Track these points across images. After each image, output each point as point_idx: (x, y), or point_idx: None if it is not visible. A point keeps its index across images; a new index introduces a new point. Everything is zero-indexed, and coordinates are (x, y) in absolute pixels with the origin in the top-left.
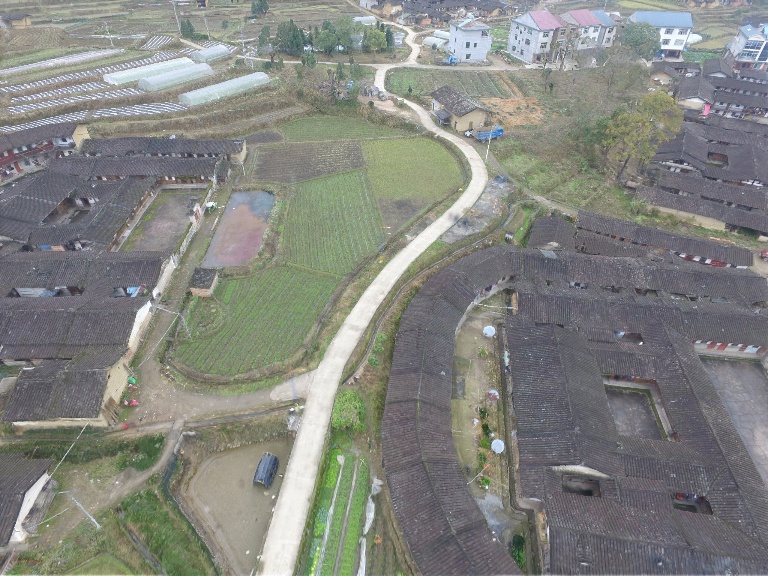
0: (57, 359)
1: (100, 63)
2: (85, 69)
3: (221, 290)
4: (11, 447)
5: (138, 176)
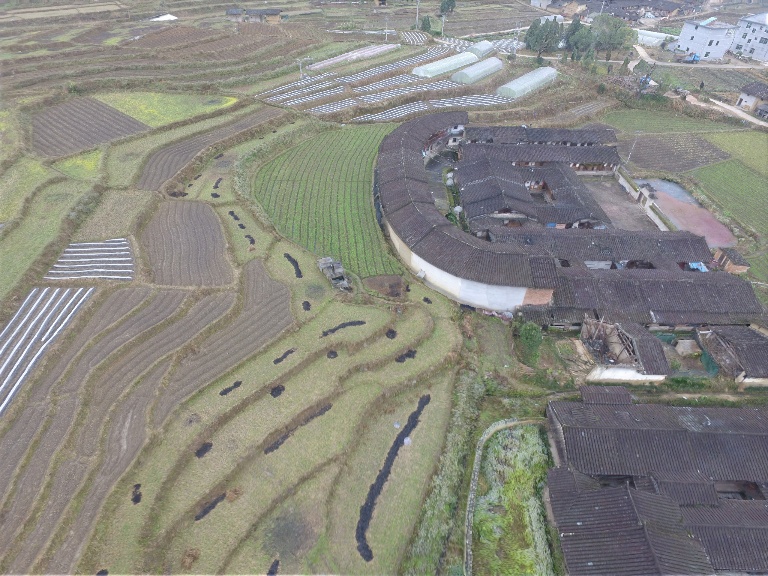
0: (701, 325)
1: (393, 57)
2: (387, 62)
3: None
4: (748, 402)
5: (550, 162)
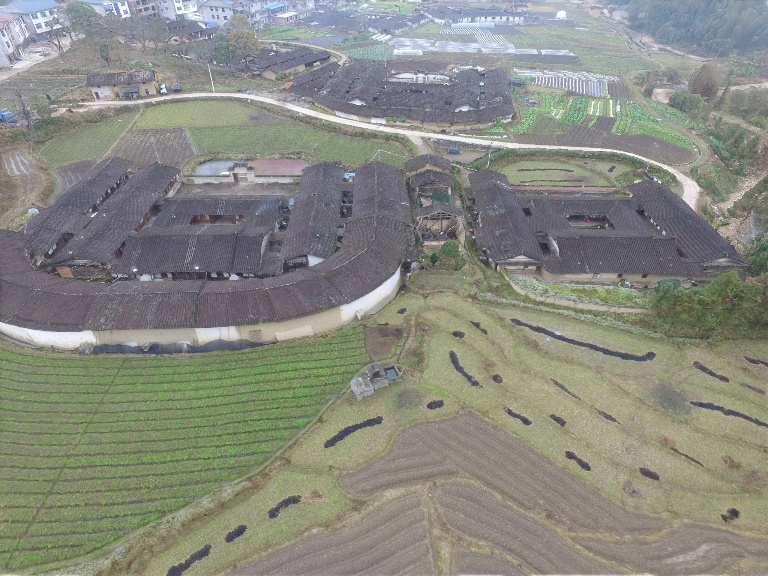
0: None
1: None
2: None
3: None
4: None
5: None
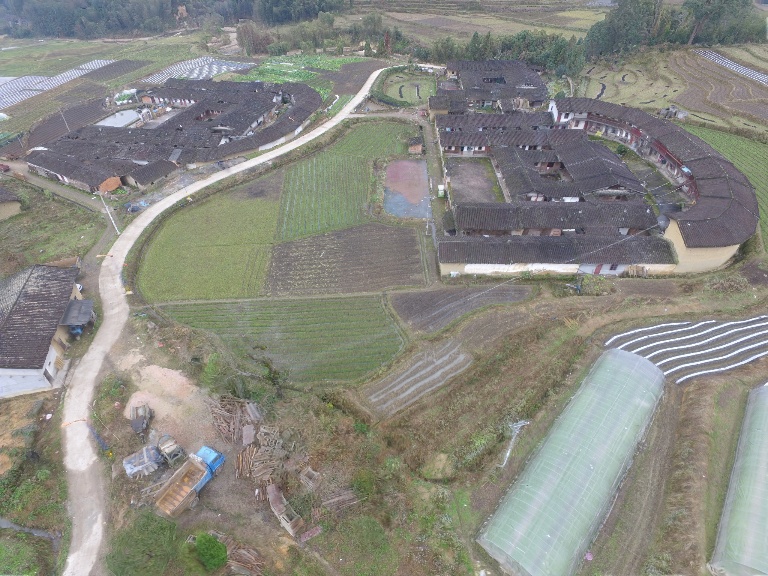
0: None
1: None
2: None
3: (405, 148)
4: None
5: None
